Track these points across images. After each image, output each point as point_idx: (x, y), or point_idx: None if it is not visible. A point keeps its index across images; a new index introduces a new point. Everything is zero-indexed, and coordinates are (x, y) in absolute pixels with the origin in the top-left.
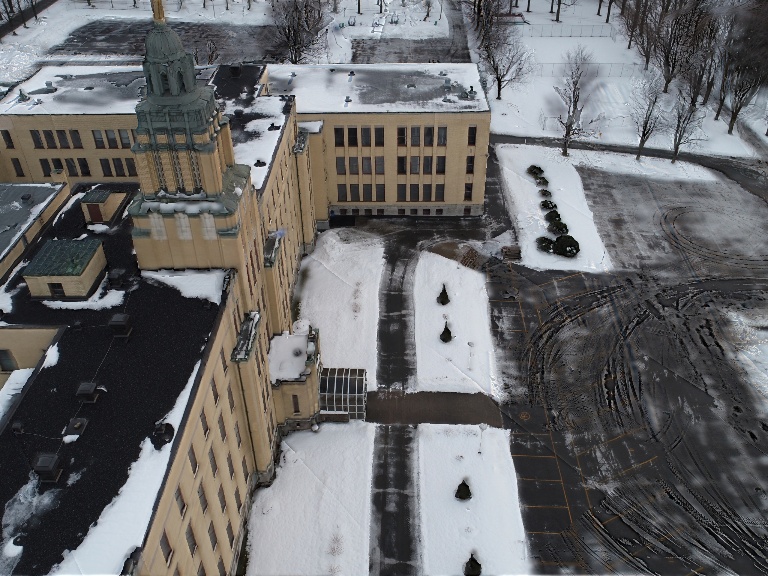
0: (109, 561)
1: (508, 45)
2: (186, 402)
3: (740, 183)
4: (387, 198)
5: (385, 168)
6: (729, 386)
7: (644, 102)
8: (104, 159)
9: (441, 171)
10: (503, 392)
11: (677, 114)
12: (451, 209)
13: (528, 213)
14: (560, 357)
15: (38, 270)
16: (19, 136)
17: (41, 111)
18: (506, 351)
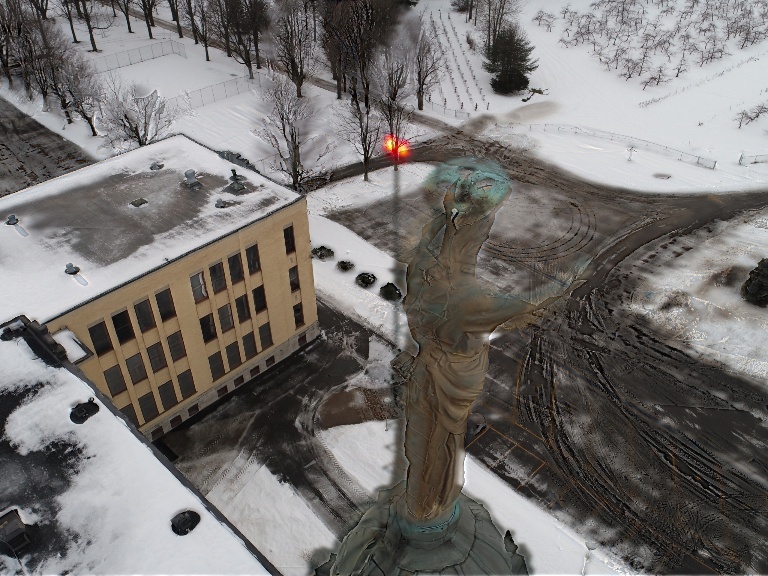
0: None
1: (106, 95)
2: None
3: (462, 166)
4: (198, 386)
5: (185, 346)
6: (736, 388)
7: (352, 115)
8: None
9: (261, 307)
10: (638, 573)
11: (384, 117)
12: (284, 349)
13: (363, 302)
14: (611, 471)
15: None
16: None
17: None
18: (566, 509)
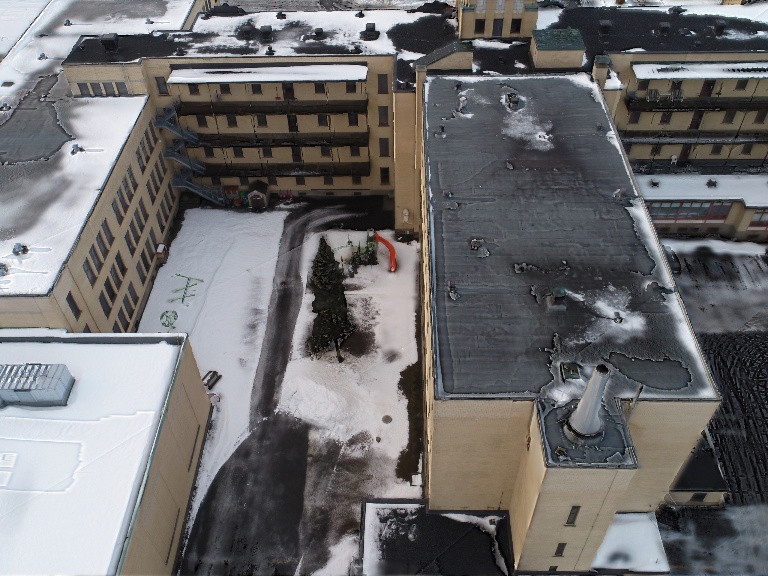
0: (753, 8)
1: None
2: (652, 7)
3: None
4: None
5: None
6: None
7: None
8: (126, 234)
9: None
10: None
11: None
12: None
13: None
14: None
15: (580, 42)
16: (80, 287)
17: (66, 234)
18: None
